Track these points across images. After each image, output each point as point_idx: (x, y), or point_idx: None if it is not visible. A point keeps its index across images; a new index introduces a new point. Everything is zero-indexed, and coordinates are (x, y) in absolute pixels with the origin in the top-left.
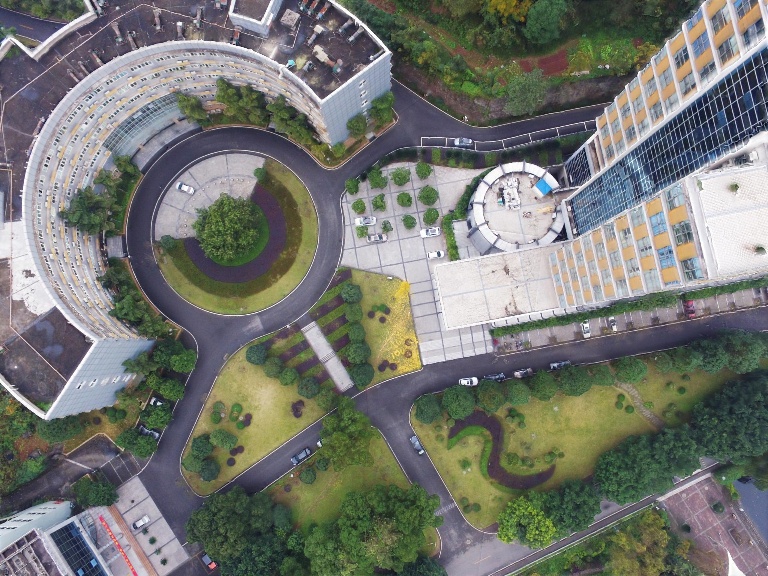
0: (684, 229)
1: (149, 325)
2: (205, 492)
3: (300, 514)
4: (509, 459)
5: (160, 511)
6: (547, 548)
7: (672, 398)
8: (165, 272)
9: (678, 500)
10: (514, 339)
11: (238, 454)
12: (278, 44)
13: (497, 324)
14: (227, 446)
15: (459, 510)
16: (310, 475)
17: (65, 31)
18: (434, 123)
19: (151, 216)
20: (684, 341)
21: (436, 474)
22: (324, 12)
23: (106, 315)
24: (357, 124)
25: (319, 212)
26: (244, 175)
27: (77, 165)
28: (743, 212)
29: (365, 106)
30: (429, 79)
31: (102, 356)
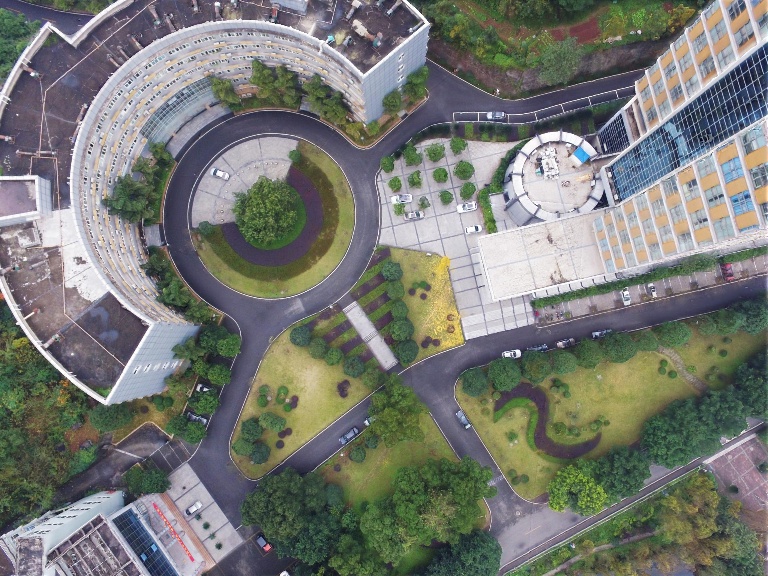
0: (764, 171)
1: (196, 310)
2: (256, 475)
3: (351, 493)
4: (557, 428)
5: (212, 496)
6: (596, 515)
7: (714, 361)
8: (204, 259)
9: (724, 462)
10: (555, 310)
11: (286, 436)
12: (316, 20)
13: (538, 295)
14: (277, 428)
15: (507, 482)
16: (360, 453)
17: (103, 16)
18: (465, 98)
19: (187, 203)
20: (724, 304)
21: (483, 448)
22: None
23: (154, 301)
24: (393, 100)
25: (355, 192)
26: (278, 158)
27: (116, 153)
28: None
29: (401, 82)
30: (460, 53)
31: (156, 340)
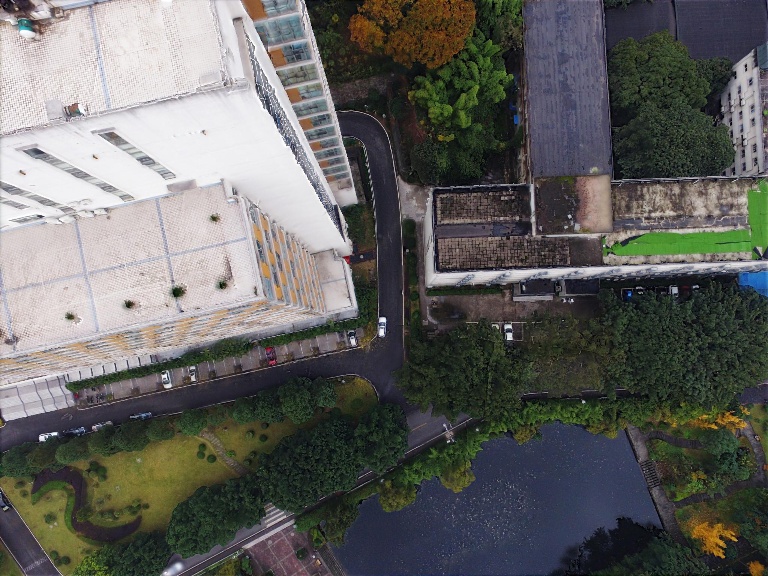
0: None
1: None
2: None
3: None
4: None
5: None
6: None
7: (255, 446)
8: None
9: (264, 547)
10: (96, 392)
11: None
12: None
13: (70, 379)
14: None
15: (52, 563)
16: None
17: None
18: None
19: None
20: None
21: (26, 529)
22: None
23: None
24: None
25: None
26: None
27: None
28: None
29: None
30: None
31: None
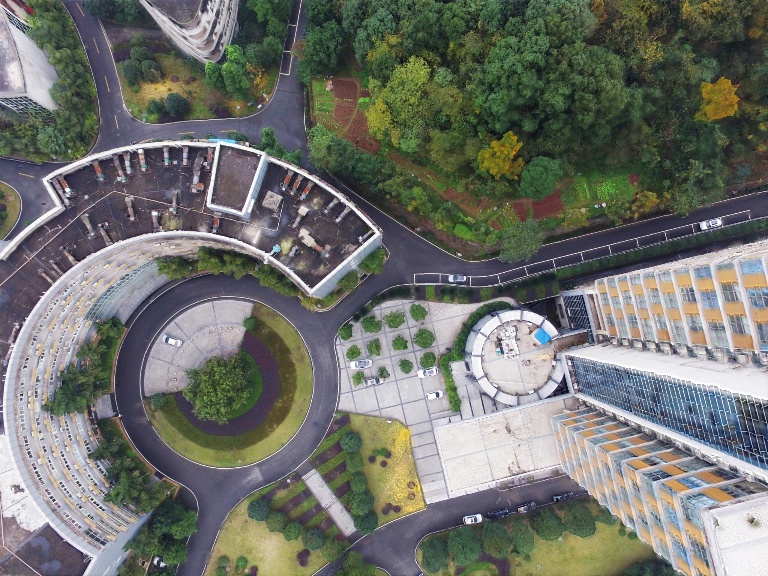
0: (698, 548)
1: (147, 505)
2: None
3: None
4: None
5: None
6: None
7: None
8: (158, 428)
9: None
10: None
11: None
12: (261, 228)
13: None
14: None
15: None
16: None
17: (32, 229)
18: (427, 258)
19: (139, 371)
20: None
21: None
22: (308, 192)
23: (101, 502)
24: (348, 284)
25: (313, 356)
26: (233, 322)
27: (57, 348)
28: (759, 541)
29: (355, 265)
30: (420, 218)
31: (102, 561)
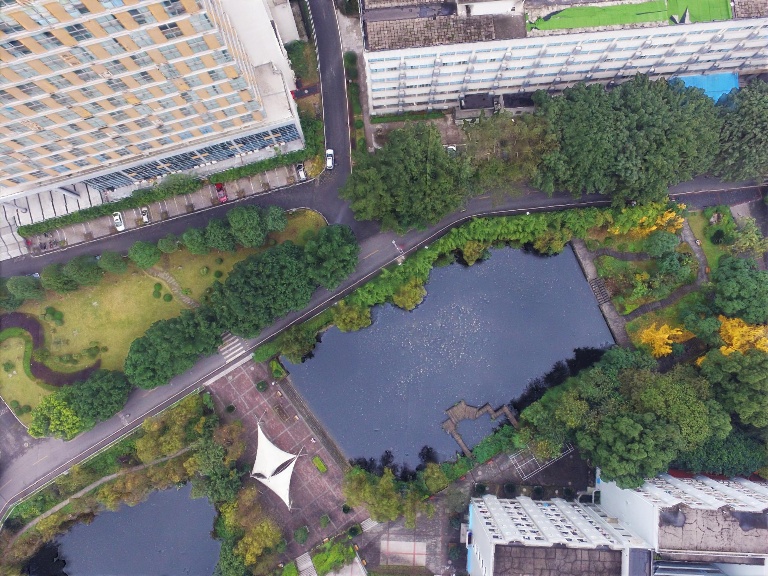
0: None
1: None
2: None
3: None
4: None
5: None
6: (101, 442)
7: None
8: None
9: (224, 383)
10: (49, 239)
11: None
12: None
13: (22, 224)
14: None
15: (13, 414)
16: None
17: None
18: None
19: None
20: None
21: None
22: None
23: None
24: None
25: None
26: None
27: None
28: None
29: None
30: None
31: None
